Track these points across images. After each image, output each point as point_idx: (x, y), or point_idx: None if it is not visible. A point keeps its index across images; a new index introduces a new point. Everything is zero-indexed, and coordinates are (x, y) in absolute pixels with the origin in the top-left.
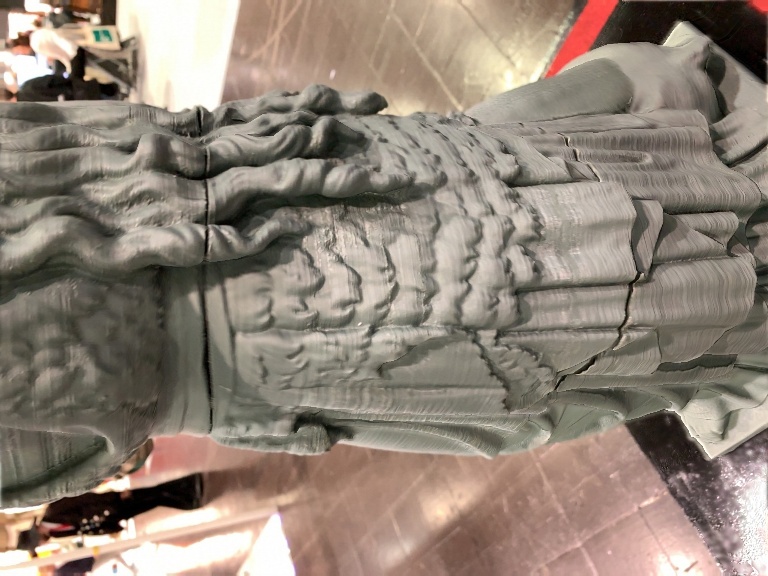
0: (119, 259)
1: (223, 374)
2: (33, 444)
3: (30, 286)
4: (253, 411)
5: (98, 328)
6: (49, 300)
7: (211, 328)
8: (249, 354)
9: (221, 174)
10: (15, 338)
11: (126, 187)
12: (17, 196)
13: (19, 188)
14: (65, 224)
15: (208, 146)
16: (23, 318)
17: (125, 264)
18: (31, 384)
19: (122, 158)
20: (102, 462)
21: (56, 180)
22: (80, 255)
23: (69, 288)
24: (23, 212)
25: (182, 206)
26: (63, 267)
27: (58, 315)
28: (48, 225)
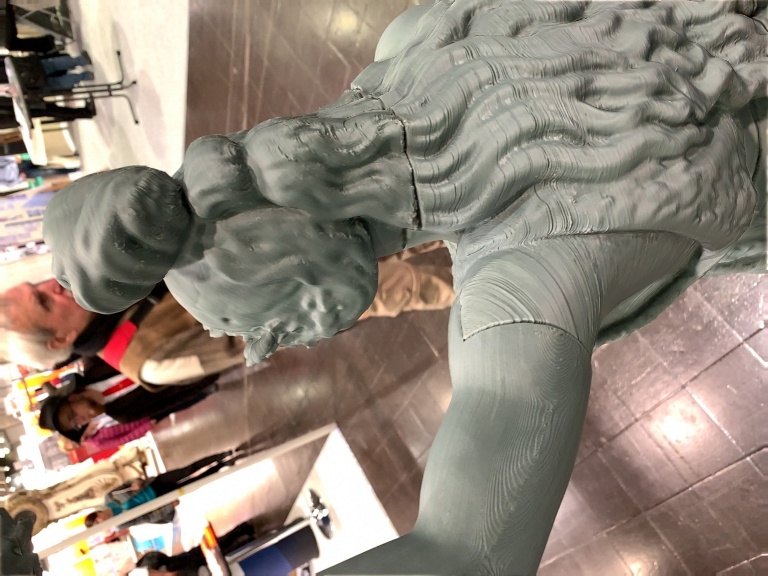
0: (751, 92)
1: (759, 197)
2: None
3: (711, 122)
4: (761, 231)
5: (742, 156)
6: (729, 132)
7: (763, 155)
8: None
9: (765, 10)
10: (728, 165)
11: (722, 30)
12: (680, 44)
13: (681, 37)
14: (727, 63)
15: None
16: (729, 147)
17: (751, 96)
18: (736, 204)
19: (703, 5)
20: (684, 288)
21: (678, 30)
22: (732, 91)
23: (731, 121)
24: (696, 57)
25: (760, 41)
26: (715, 105)
27: (735, 144)
28: (718, 65)
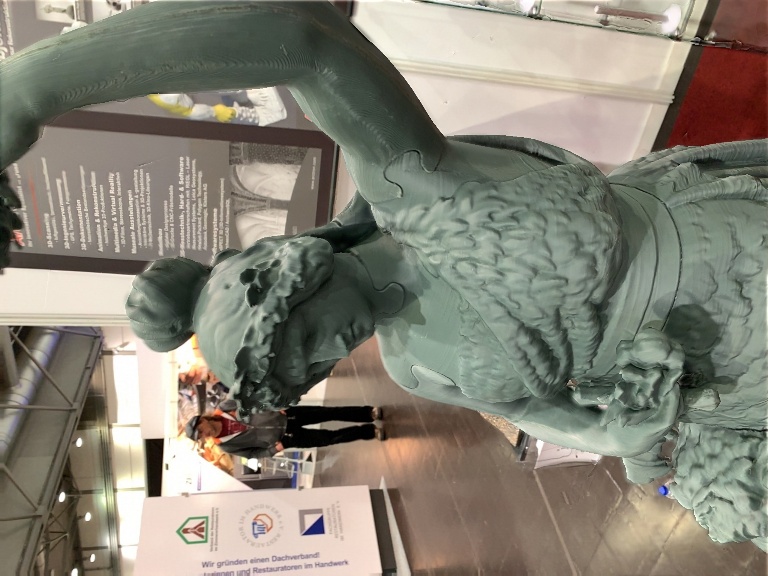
0: None
1: None
2: None
3: None
4: None
5: None
6: None
7: None
8: None
9: None
10: None
11: None
12: None
13: None
14: None
15: None
16: None
17: None
18: None
19: None
20: None
21: None
22: None
23: None
24: None
25: None
26: None
27: None
28: None
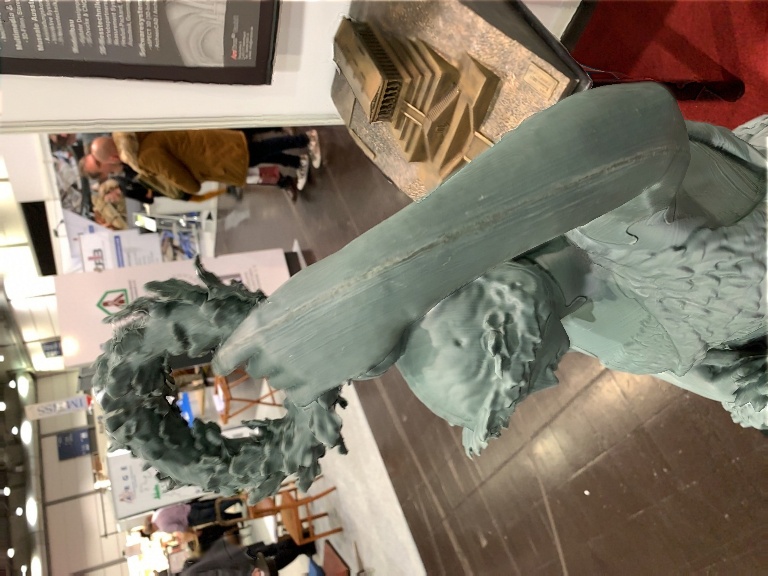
0: None
1: None
2: (723, 162)
3: None
4: None
5: None
6: None
7: None
8: (761, 138)
9: None
10: None
11: None
12: None
13: None
14: None
15: None
16: None
17: None
18: None
19: None
20: None
21: None
22: None
23: None
24: None
25: None
26: None
27: None
28: None
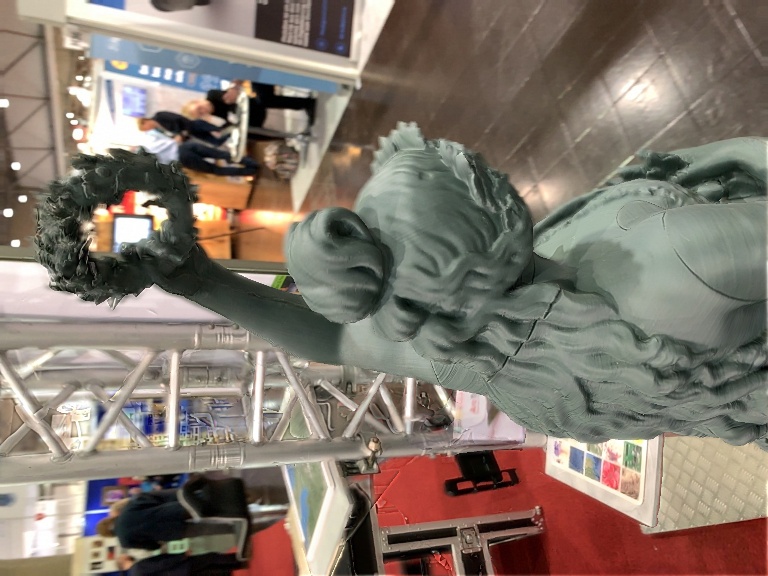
0: None
1: None
2: None
3: None
4: None
5: None
6: None
7: None
8: None
9: None
10: None
11: None
12: None
13: None
14: None
15: (767, 435)
16: None
17: None
18: None
19: (720, 431)
20: None
21: None
22: None
23: None
24: None
25: None
26: None
27: None
28: None
